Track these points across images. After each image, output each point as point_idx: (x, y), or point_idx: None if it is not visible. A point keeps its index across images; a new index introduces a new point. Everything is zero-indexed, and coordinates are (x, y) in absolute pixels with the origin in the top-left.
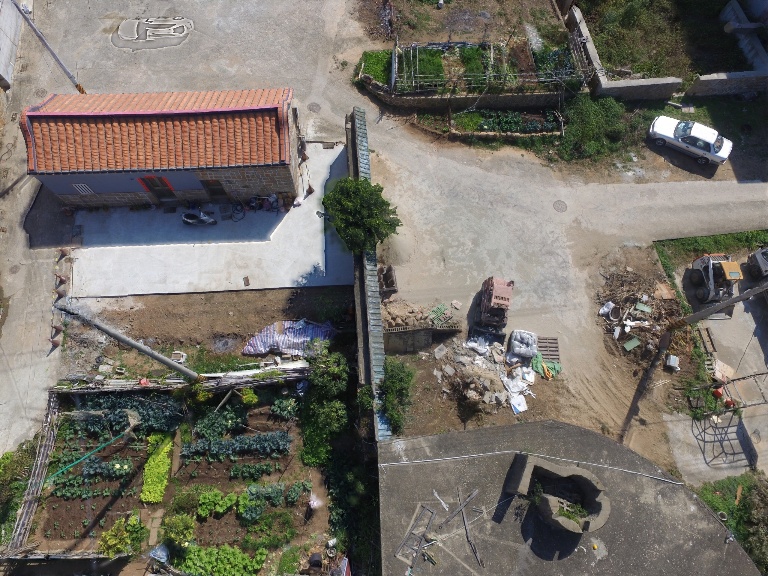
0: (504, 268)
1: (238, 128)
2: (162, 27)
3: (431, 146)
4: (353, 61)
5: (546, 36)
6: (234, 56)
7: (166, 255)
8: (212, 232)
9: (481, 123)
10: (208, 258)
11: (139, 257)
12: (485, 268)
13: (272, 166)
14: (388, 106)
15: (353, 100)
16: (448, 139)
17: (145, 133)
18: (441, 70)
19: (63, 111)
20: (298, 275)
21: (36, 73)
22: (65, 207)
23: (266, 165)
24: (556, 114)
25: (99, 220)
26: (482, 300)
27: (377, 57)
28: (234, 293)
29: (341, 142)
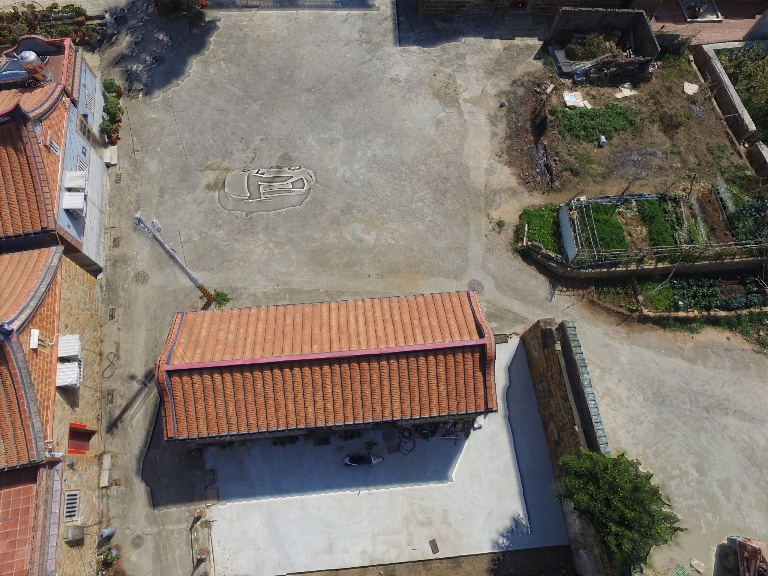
0: (742, 506)
1: (432, 368)
2: (277, 181)
3: (618, 330)
4: (511, 220)
5: (732, 180)
6: (369, 218)
7: (326, 510)
8: (379, 472)
9: (675, 299)
10: (380, 512)
11: (293, 514)
12: (720, 507)
13: (475, 413)
14: (559, 277)
15: (518, 272)
16: (638, 320)
17: (314, 380)
18: (623, 234)
19: (207, 354)
20: (497, 533)
21: (132, 250)
22: (191, 444)
23: (468, 413)
24: (759, 282)
25: (235, 460)
26: (741, 571)
27: (543, 217)
28: (420, 564)
29: (515, 333)
